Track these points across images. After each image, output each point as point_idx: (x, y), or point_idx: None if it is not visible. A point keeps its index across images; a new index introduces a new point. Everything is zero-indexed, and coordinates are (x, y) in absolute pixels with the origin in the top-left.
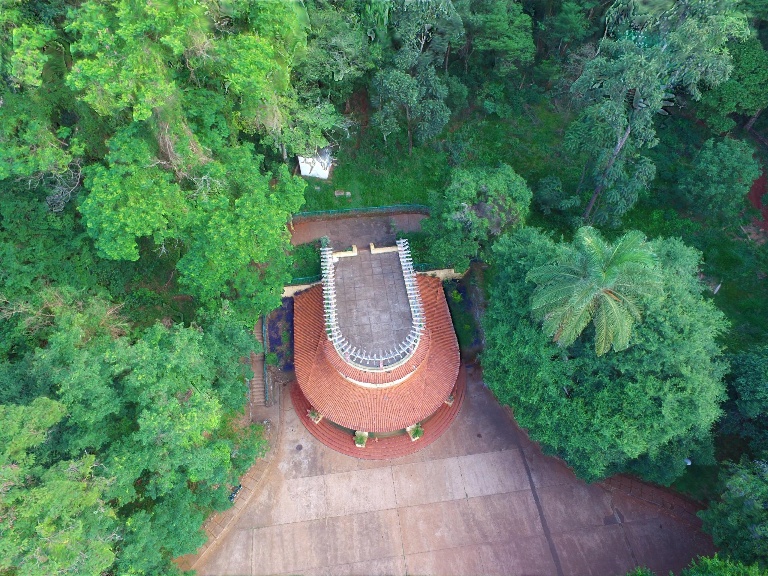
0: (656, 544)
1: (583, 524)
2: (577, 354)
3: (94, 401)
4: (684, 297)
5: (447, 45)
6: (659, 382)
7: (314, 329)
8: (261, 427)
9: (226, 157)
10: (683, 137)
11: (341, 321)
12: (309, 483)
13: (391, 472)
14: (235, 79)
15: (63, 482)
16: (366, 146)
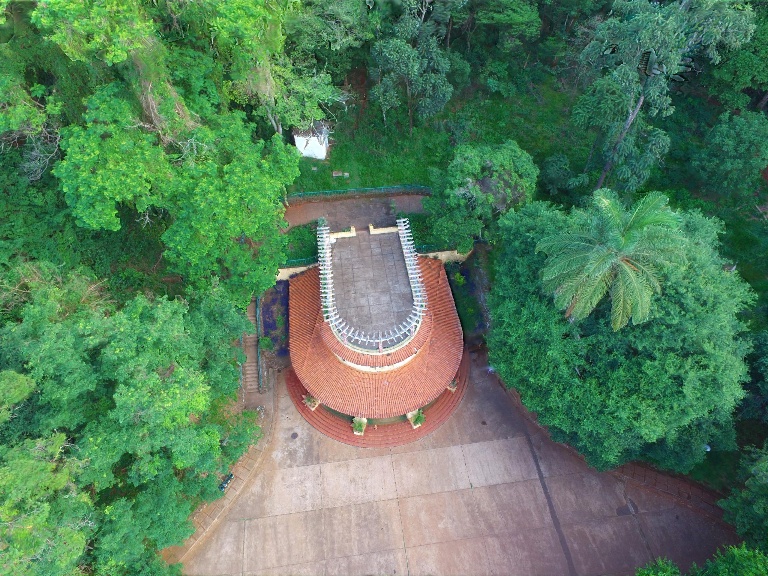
0: (672, 536)
1: (595, 515)
2: (590, 332)
3: (67, 376)
4: (707, 267)
5: (449, 14)
6: (679, 359)
7: (310, 312)
8: (254, 414)
9: (216, 125)
10: (694, 115)
11: (338, 303)
12: (304, 472)
13: (391, 461)
14: (220, 23)
15: (28, 461)
16: (365, 126)
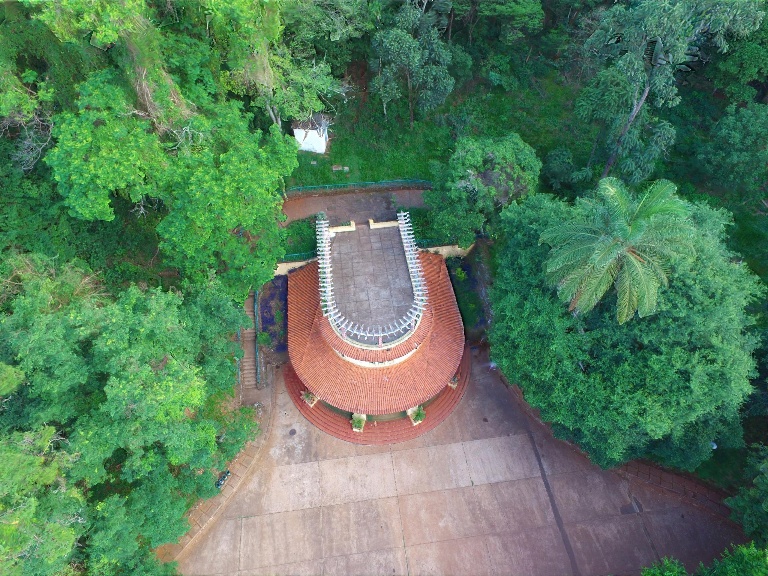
0: (678, 535)
1: (598, 513)
2: (594, 326)
3: (57, 368)
4: (715, 259)
5: (451, 4)
6: (686, 354)
7: (309, 307)
8: (252, 410)
9: (212, 115)
10: (699, 109)
11: (337, 297)
12: (303, 470)
13: (391, 458)
14: (215, 4)
15: (14, 455)
16: (365, 120)
